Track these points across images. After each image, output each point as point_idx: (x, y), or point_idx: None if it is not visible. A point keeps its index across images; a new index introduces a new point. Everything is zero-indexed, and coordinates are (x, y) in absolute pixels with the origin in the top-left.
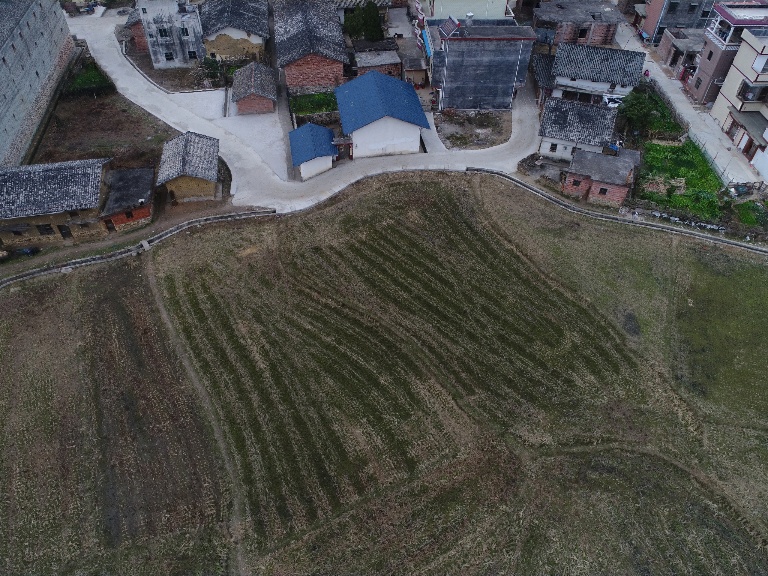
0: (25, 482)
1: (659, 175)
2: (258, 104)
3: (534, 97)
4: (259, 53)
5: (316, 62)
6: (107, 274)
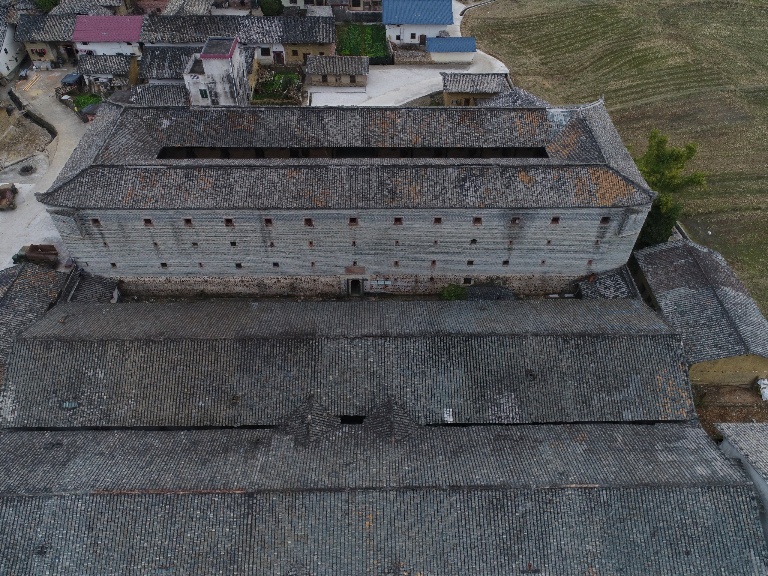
0: None
1: None
2: None
3: None
4: (259, 67)
5: None
6: None
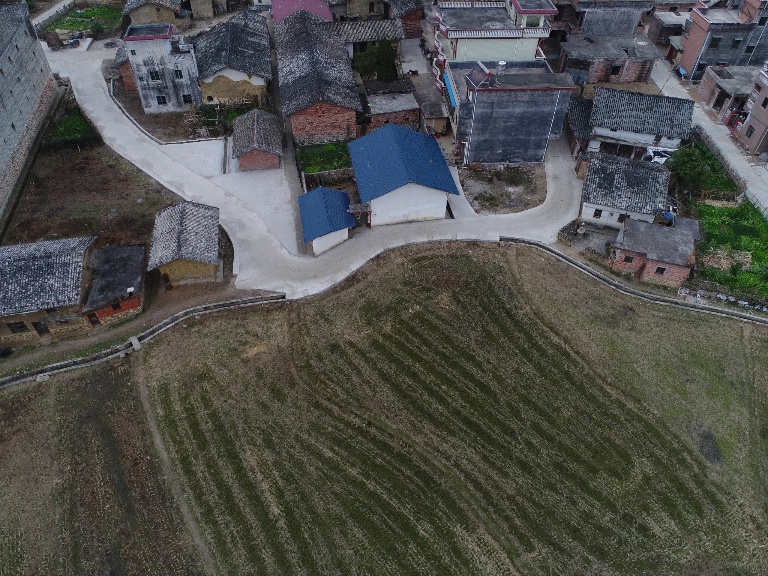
0: None
1: (719, 246)
2: (262, 159)
3: (568, 147)
4: (261, 95)
5: (326, 110)
6: (90, 382)
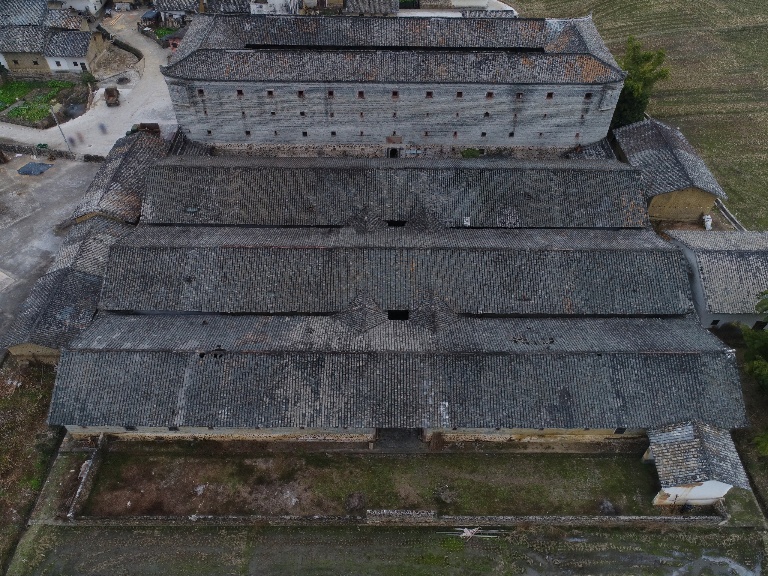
0: None
1: None
2: None
3: None
4: None
5: None
6: None
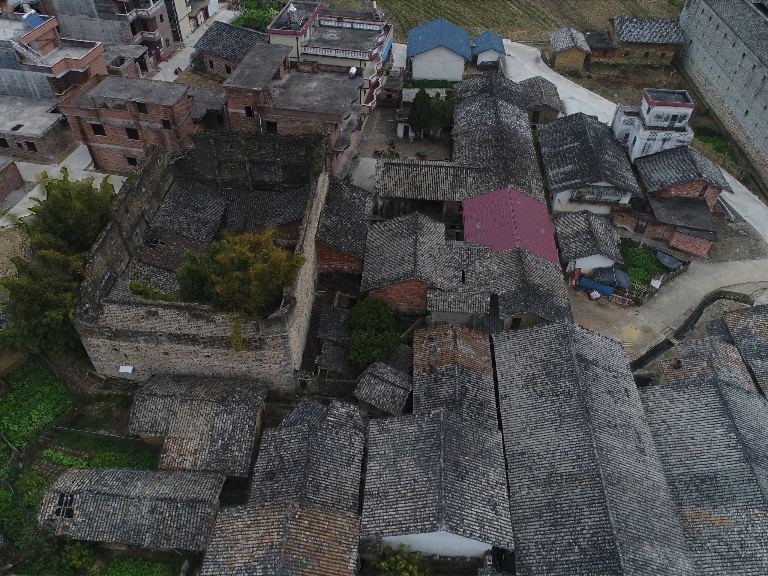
0: None
1: None
2: None
3: None
4: None
5: None
6: None
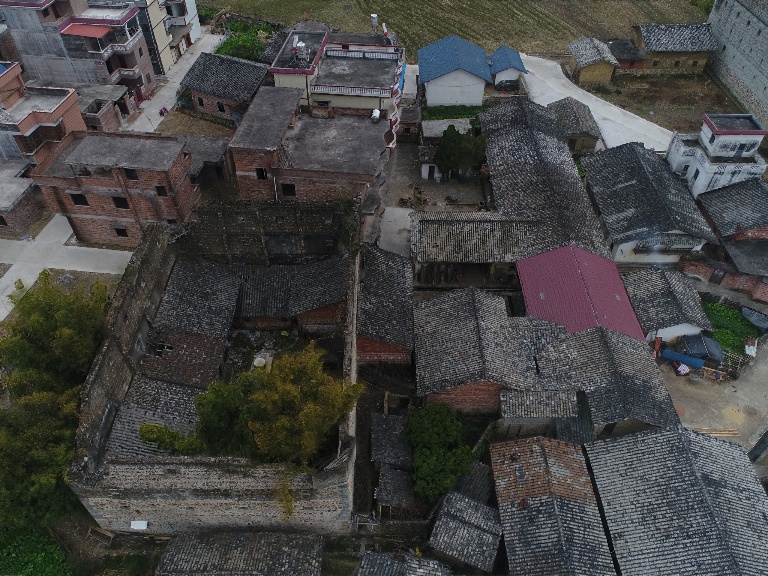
0: (594, 0)
1: None
2: None
3: None
4: None
5: None
6: None
